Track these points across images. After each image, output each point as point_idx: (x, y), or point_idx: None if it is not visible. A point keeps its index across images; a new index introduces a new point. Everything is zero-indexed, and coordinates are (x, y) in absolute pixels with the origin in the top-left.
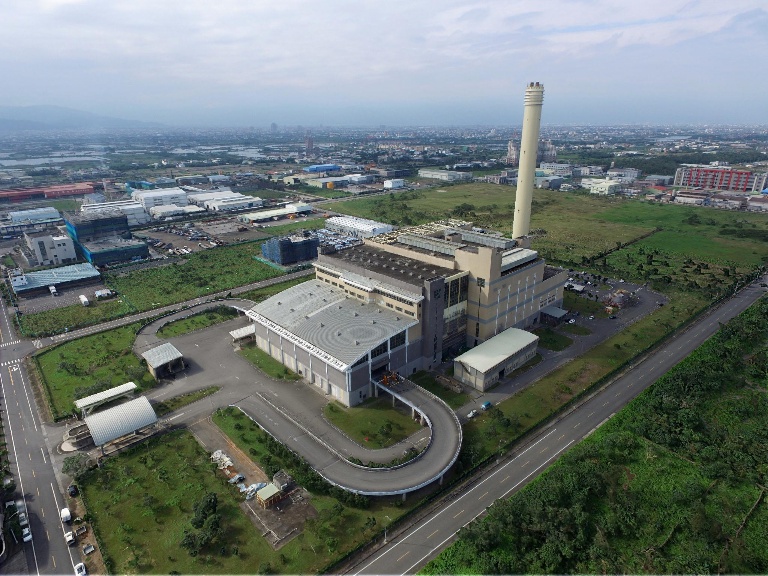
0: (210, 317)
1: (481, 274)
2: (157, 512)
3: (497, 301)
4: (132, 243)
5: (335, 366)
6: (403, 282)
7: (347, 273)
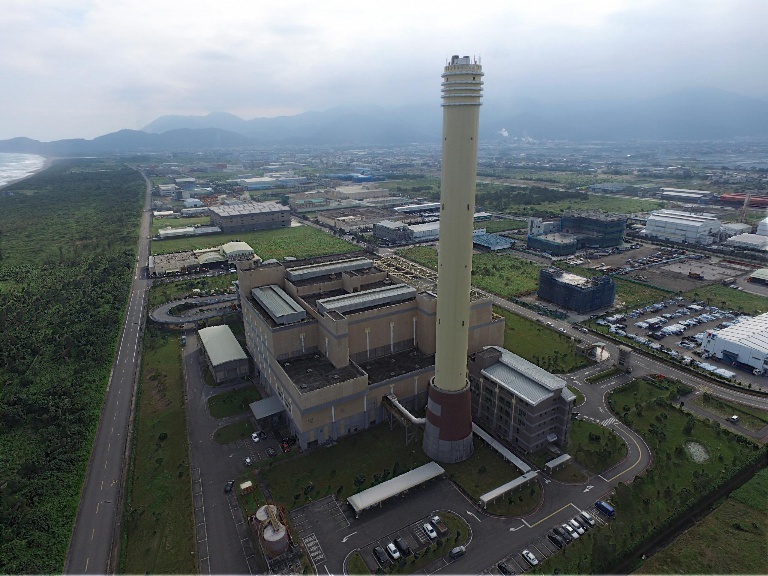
0: None
1: None
2: None
3: None
4: (567, 241)
5: None
6: None
7: None
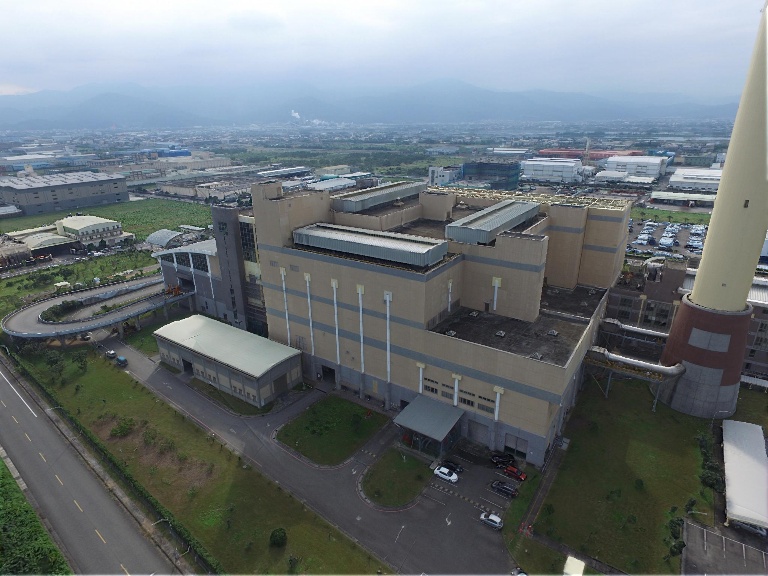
0: None
1: None
2: None
3: (283, 287)
4: None
5: None
6: None
7: None
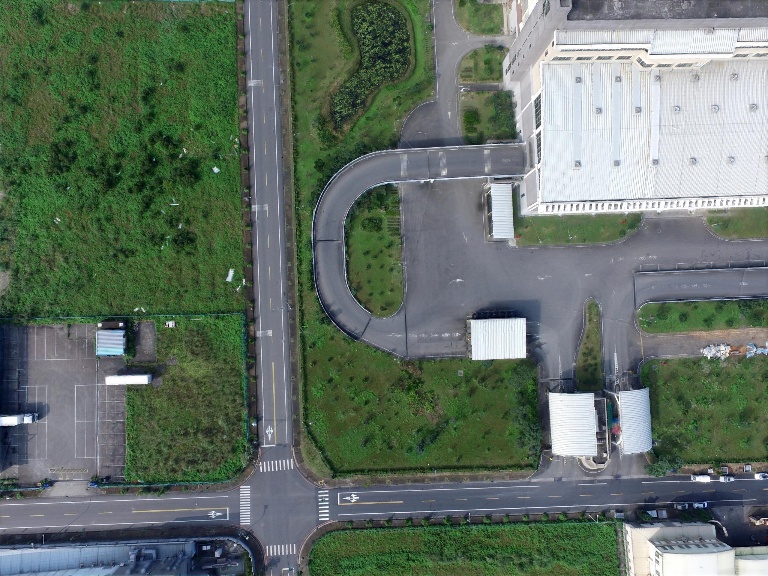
0: (377, 227)
1: None
2: (744, 417)
3: None
4: None
5: None
6: None
7: (658, 38)
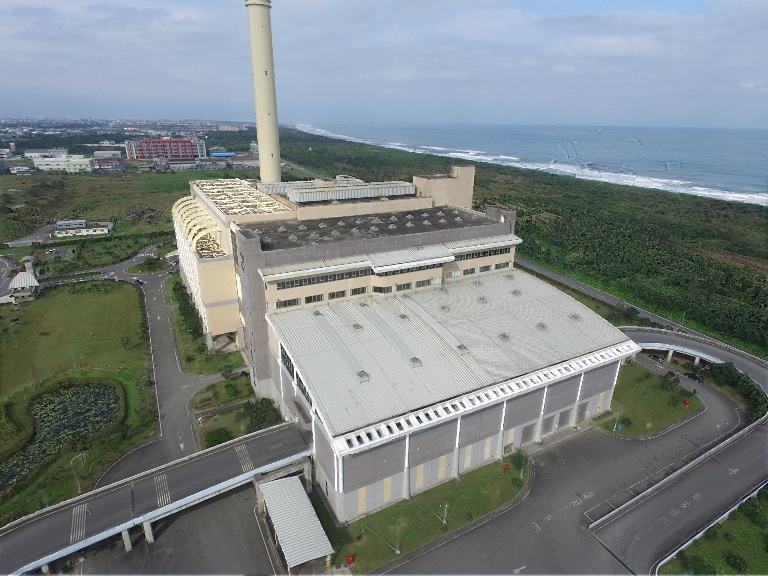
0: None
1: (463, 202)
2: None
3: None
4: None
5: (630, 352)
6: (482, 226)
7: (373, 257)
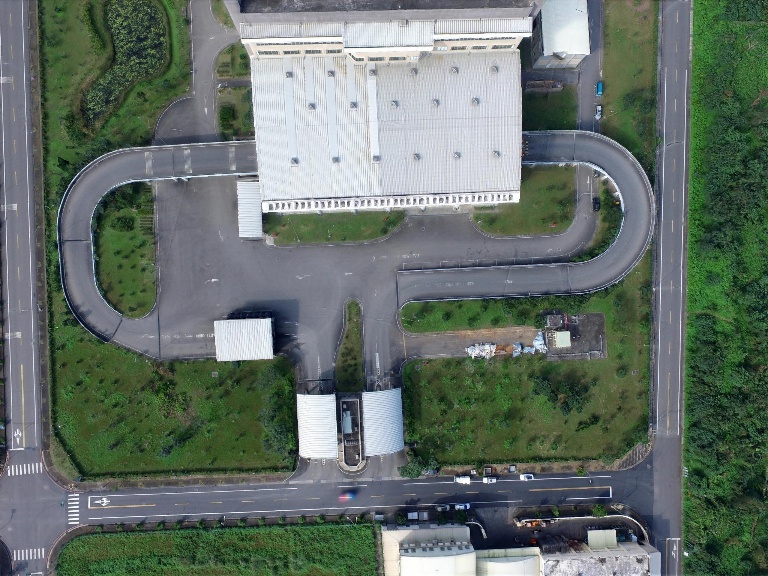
0: (127, 227)
1: None
2: (509, 418)
3: None
4: None
5: None
6: (490, 10)
7: (349, 31)
